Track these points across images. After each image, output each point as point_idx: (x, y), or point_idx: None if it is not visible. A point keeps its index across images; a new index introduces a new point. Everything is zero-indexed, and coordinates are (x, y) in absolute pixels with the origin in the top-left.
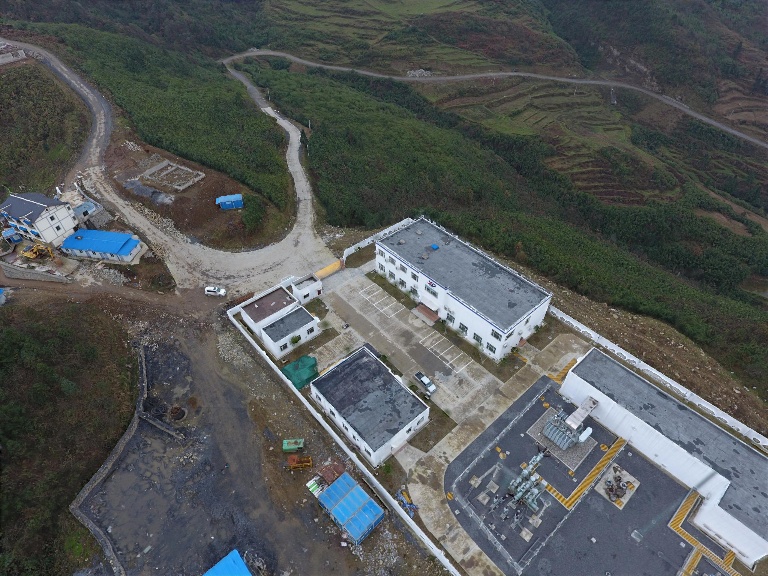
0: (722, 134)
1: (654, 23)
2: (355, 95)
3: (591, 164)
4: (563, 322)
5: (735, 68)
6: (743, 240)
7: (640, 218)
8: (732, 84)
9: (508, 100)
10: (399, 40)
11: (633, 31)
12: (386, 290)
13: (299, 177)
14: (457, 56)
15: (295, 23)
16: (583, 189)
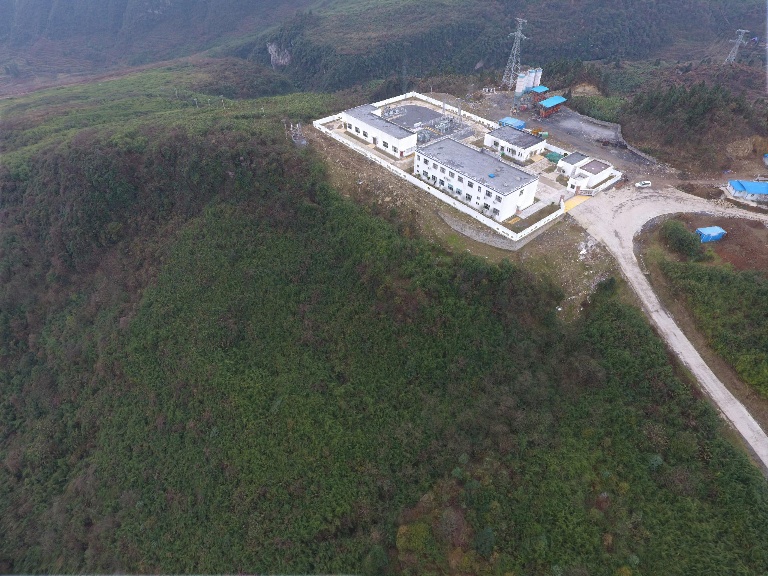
0: None
1: None
2: None
3: None
4: (400, 174)
5: None
6: None
7: None
8: None
9: None
10: None
11: None
12: None
13: (709, 379)
14: None
15: None
16: None
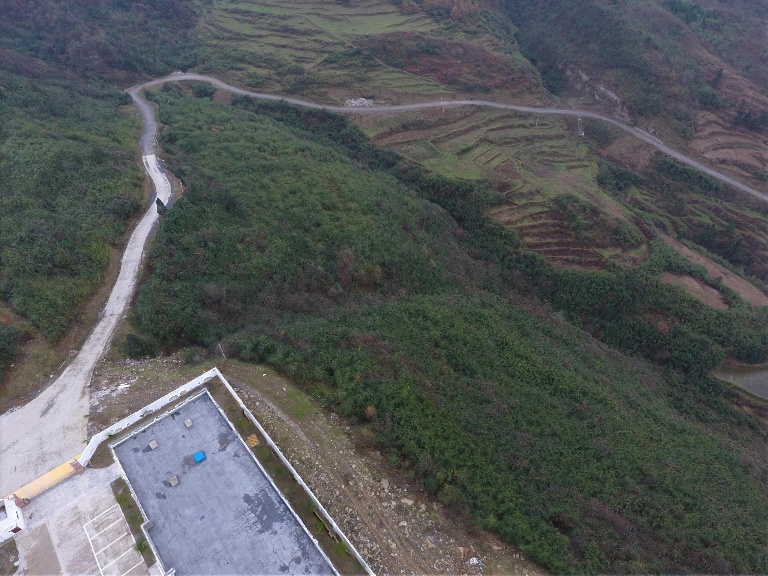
0: (699, 175)
1: (625, 46)
2: (275, 132)
3: (544, 215)
4: None
5: (715, 98)
6: (717, 315)
7: (596, 286)
8: (711, 116)
9: (458, 134)
10: (340, 64)
11: (603, 54)
12: (128, 519)
13: (127, 271)
14: (405, 82)
15: (227, 43)
16: (533, 247)
